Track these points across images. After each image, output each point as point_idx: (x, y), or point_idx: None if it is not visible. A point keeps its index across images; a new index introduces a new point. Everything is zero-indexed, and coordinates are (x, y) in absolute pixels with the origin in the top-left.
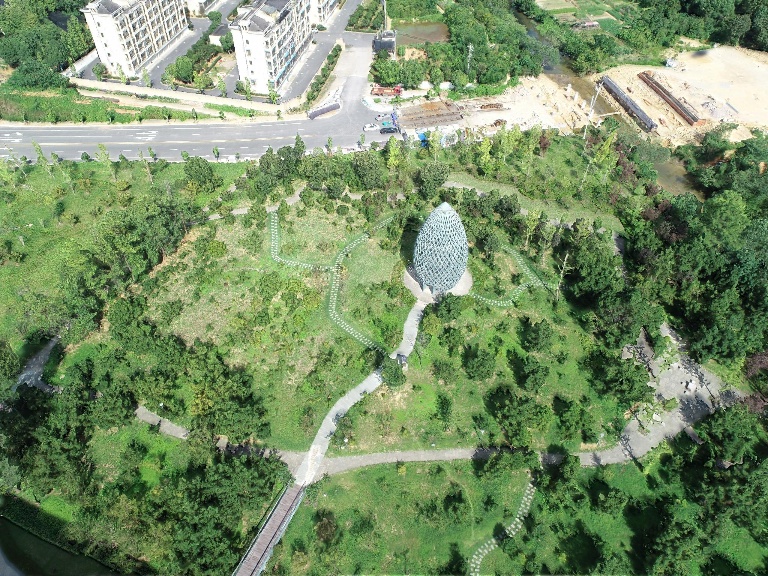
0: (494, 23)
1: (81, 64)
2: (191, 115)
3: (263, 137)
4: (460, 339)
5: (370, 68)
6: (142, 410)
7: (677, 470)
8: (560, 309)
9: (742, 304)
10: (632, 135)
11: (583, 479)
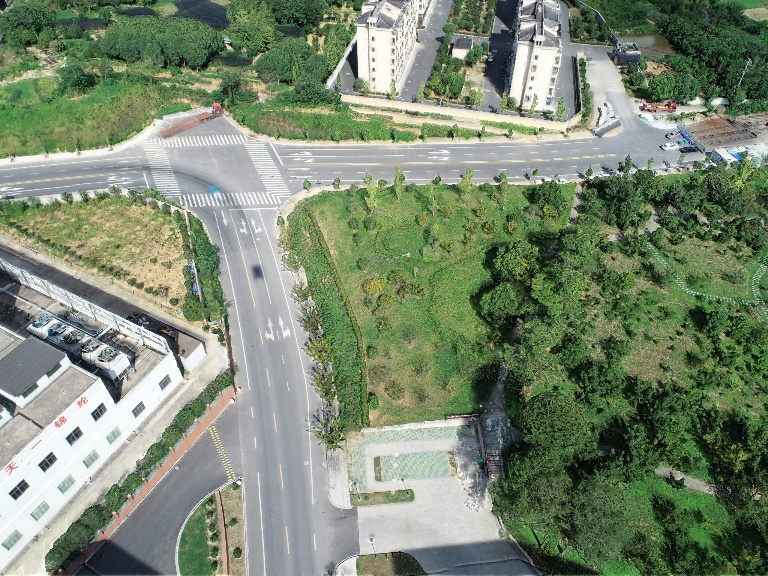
0: (725, 35)
1: (332, 79)
2: (475, 133)
3: (562, 157)
4: None
5: (622, 82)
6: None
7: None
8: None
9: None
10: None
11: None
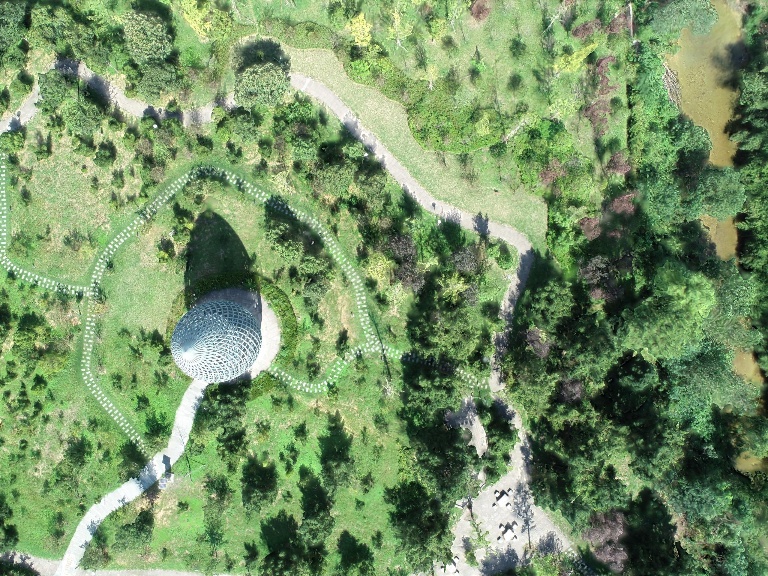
0: None
1: None
2: None
3: None
4: None
5: None
6: None
7: None
8: (386, 408)
9: (628, 435)
10: None
11: None
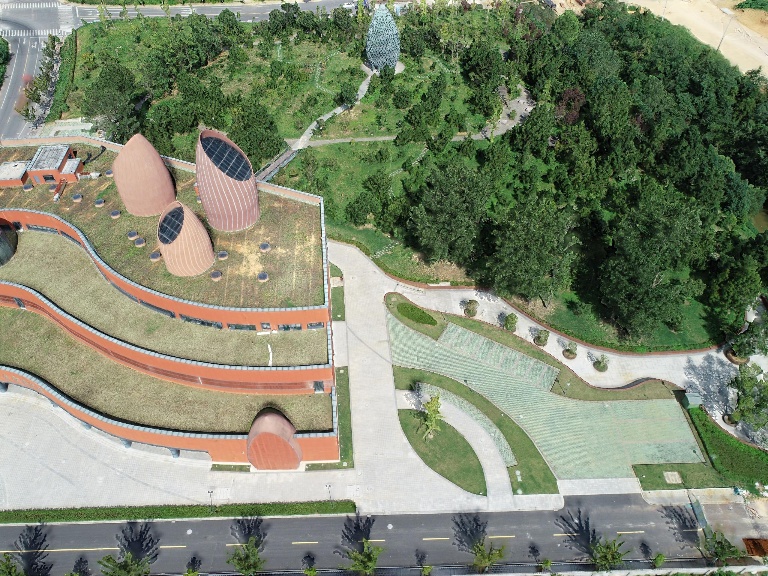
0: None
1: None
2: None
3: None
4: (392, 88)
5: None
6: (201, 126)
7: (508, 137)
8: (457, 78)
9: None
10: (532, 6)
11: (456, 145)
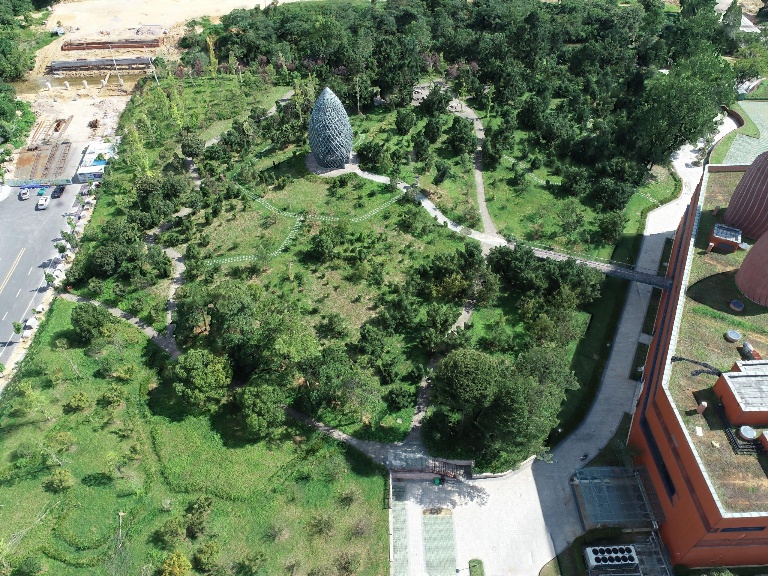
0: None
1: None
2: None
3: None
4: None
5: None
6: None
7: None
8: (373, 116)
9: None
10: (172, 63)
11: None
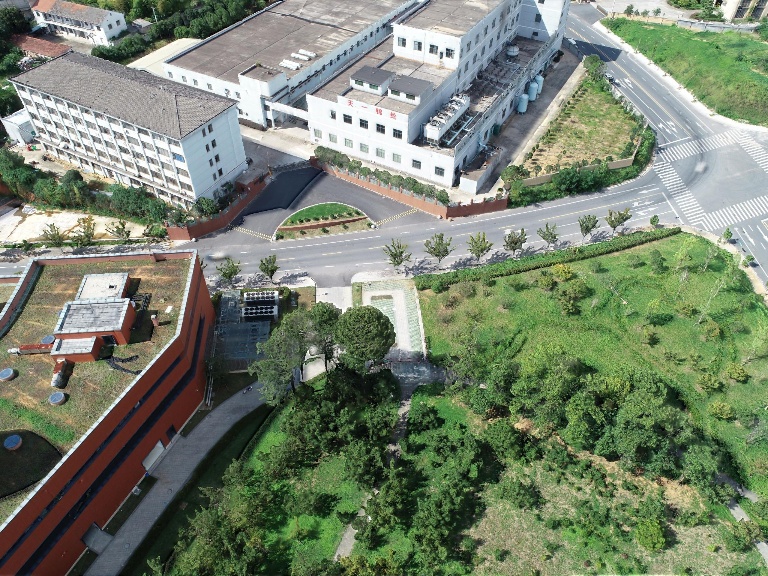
0: None
1: None
2: None
3: None
4: None
5: None
6: None
7: None
8: None
9: None
10: None
11: None
